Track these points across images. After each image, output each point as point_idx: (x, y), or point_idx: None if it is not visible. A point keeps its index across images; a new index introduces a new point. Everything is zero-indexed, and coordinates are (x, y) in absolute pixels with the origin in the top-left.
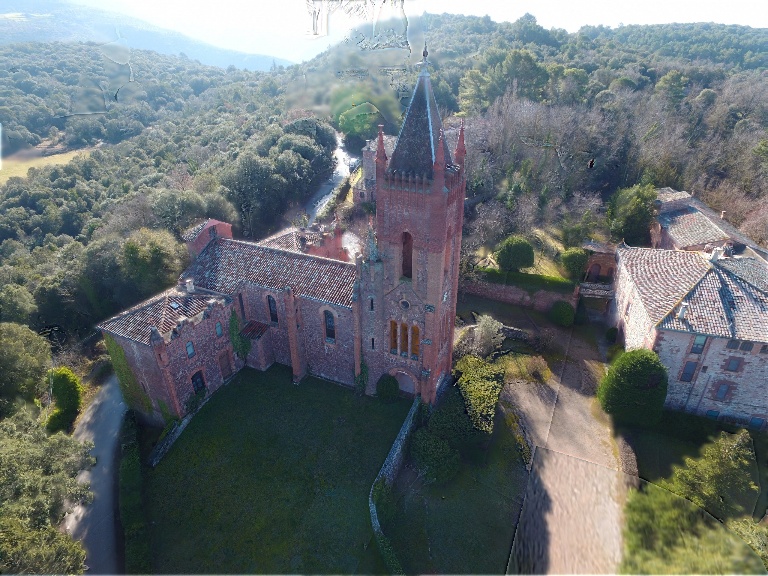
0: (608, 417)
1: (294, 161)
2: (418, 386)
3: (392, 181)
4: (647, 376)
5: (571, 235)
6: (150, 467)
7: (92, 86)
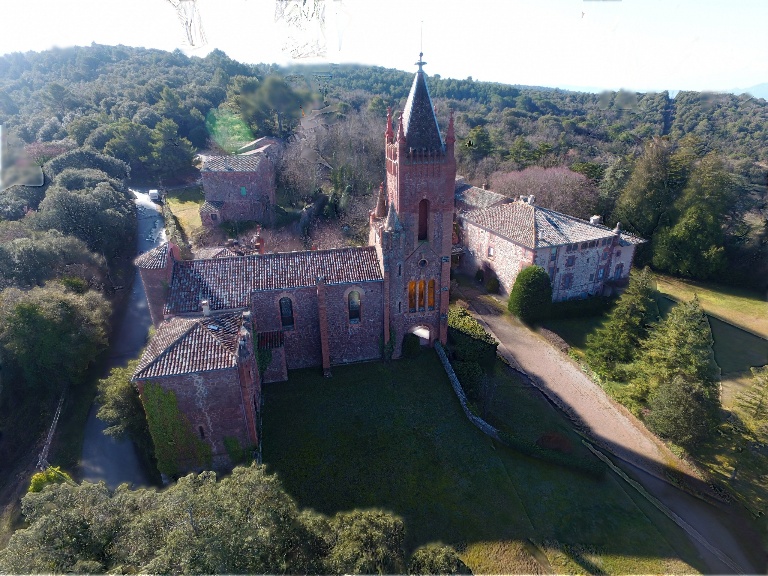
0: (520, 322)
1: None
2: (434, 333)
3: (413, 157)
4: (543, 280)
5: None
6: None
7: None
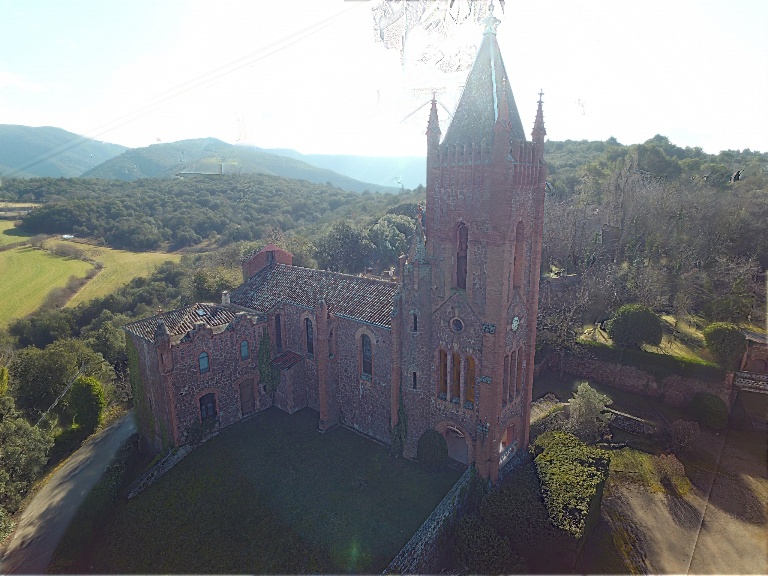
0: None
1: (388, 232)
2: (473, 451)
3: (444, 156)
4: None
5: (716, 308)
6: (125, 499)
7: (213, 151)
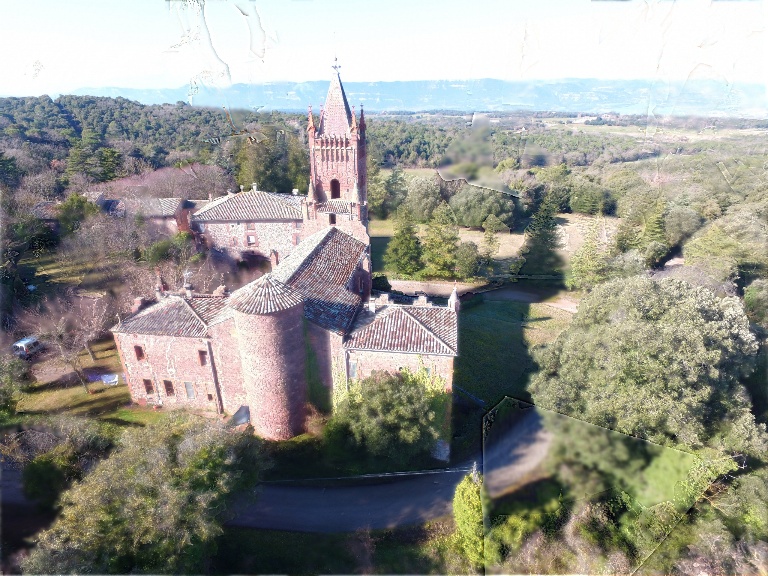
0: None
1: None
2: None
3: None
4: None
5: None
6: None
7: None
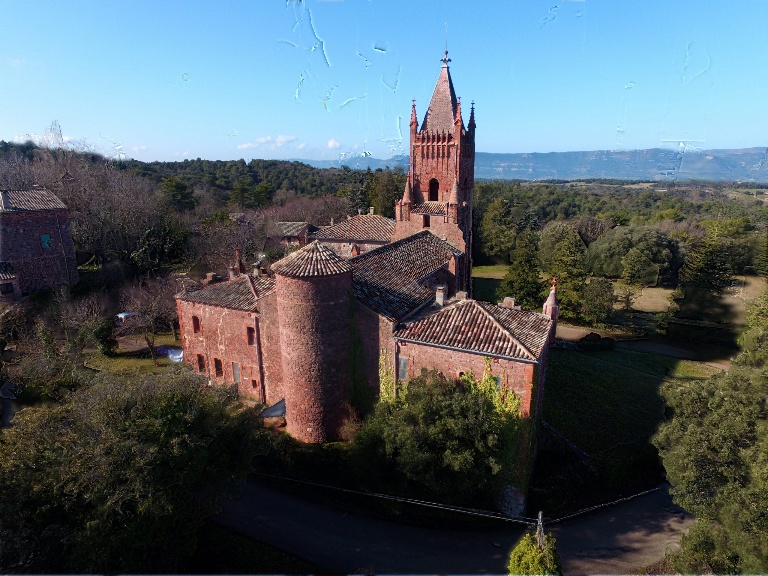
0: None
1: None
2: None
3: None
4: None
5: None
6: None
7: None
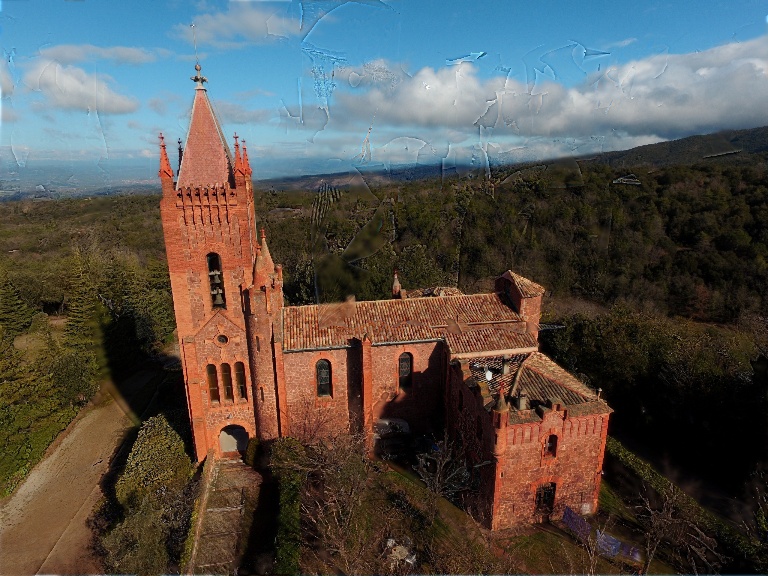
0: None
1: None
2: None
3: None
4: None
5: None
6: None
7: None
